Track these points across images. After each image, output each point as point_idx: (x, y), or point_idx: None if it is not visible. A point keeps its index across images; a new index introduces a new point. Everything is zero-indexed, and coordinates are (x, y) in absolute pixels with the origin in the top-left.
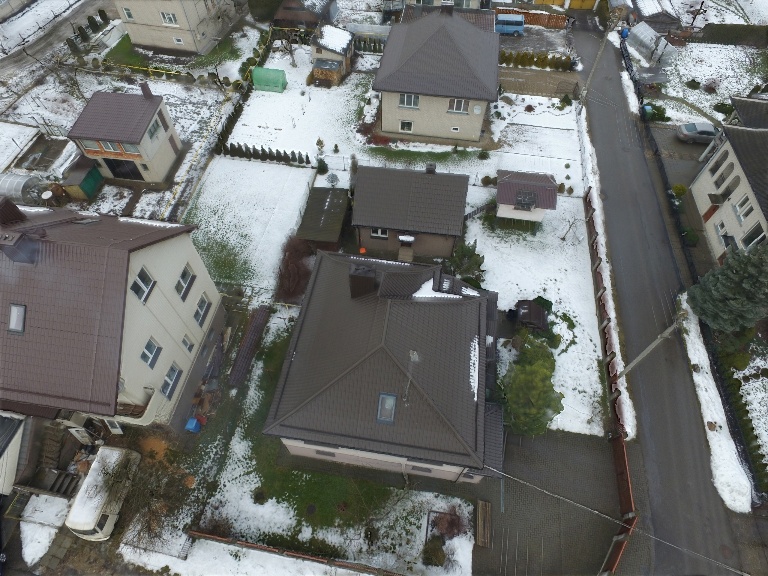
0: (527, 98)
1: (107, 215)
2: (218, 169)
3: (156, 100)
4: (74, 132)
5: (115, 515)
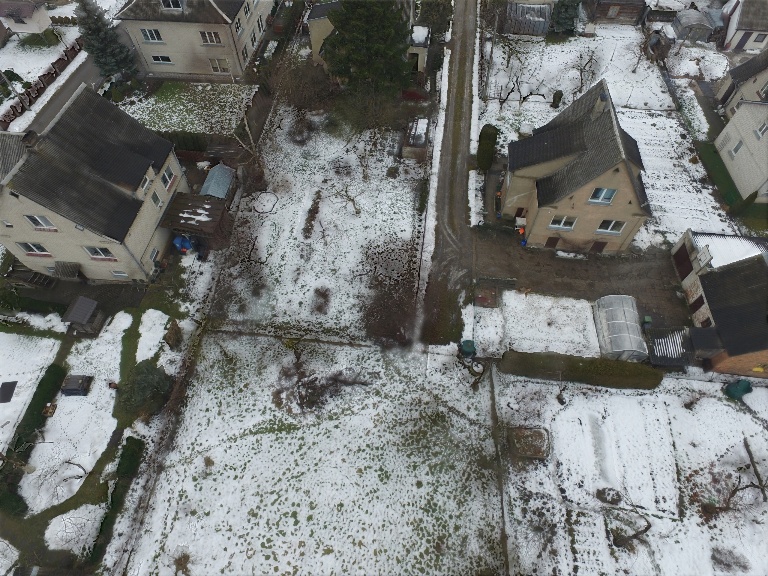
0: None
1: None
2: None
3: None
4: None
5: None
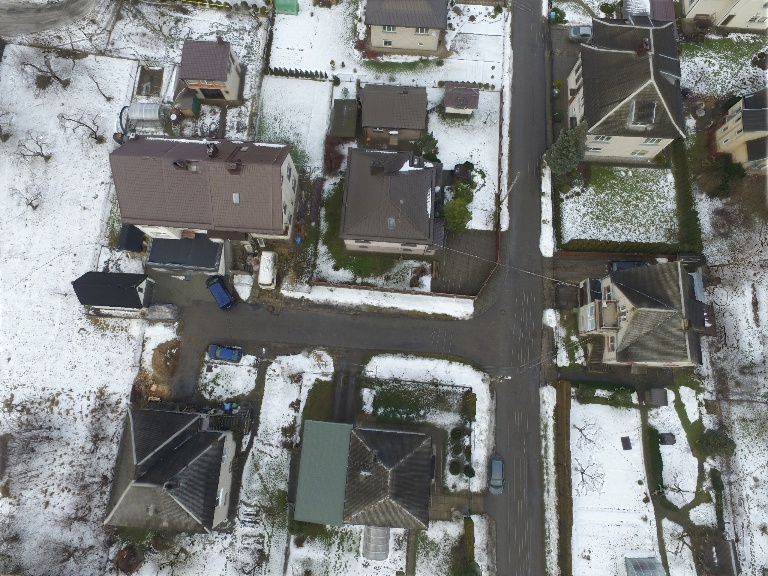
0: (471, 8)
1: (247, 142)
2: (269, 86)
3: (227, 46)
4: (183, 75)
5: None
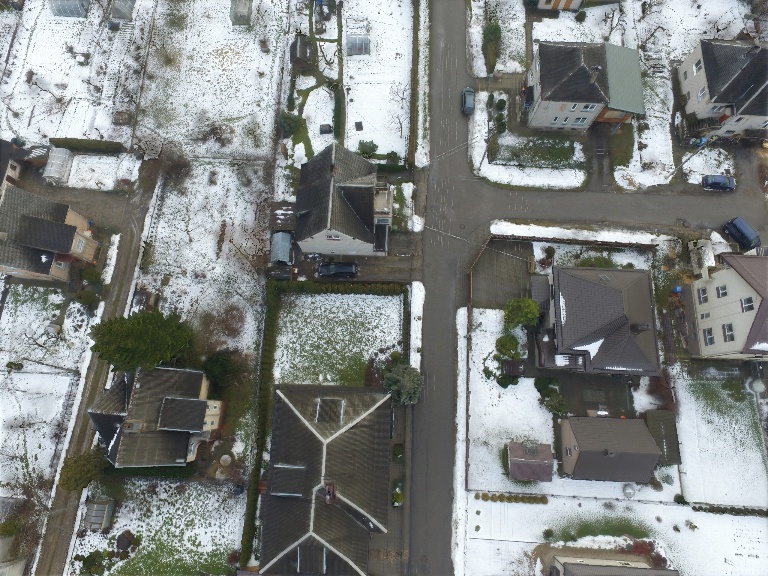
0: None
1: None
2: (765, 493)
3: None
4: None
5: None
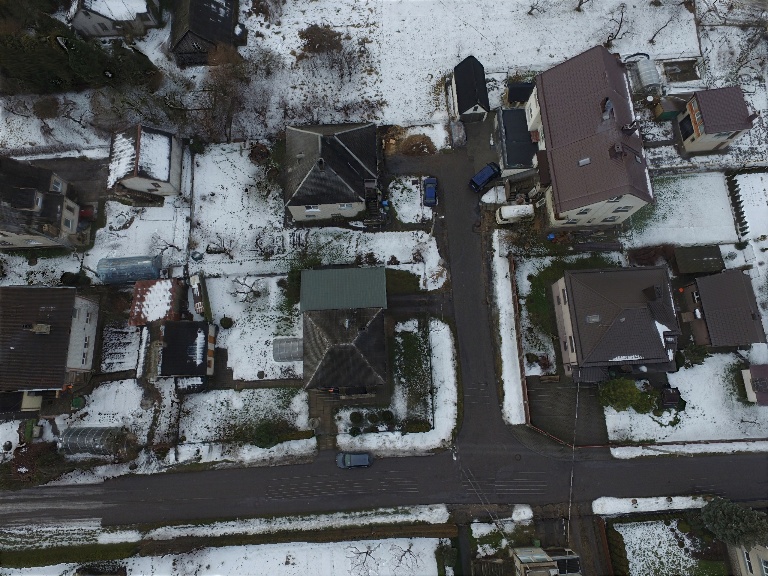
0: None
1: None
2: (712, 179)
3: (748, 126)
4: (700, 94)
5: (508, 222)
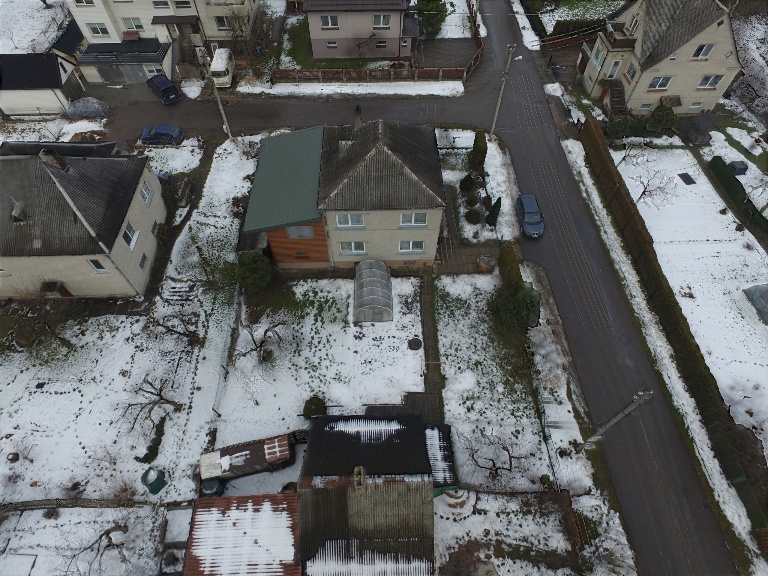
0: None
1: None
2: None
3: None
4: None
5: None
